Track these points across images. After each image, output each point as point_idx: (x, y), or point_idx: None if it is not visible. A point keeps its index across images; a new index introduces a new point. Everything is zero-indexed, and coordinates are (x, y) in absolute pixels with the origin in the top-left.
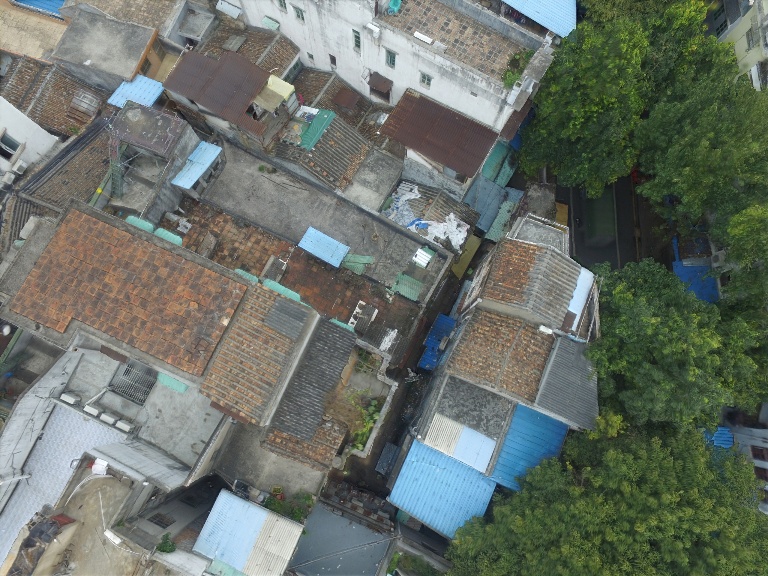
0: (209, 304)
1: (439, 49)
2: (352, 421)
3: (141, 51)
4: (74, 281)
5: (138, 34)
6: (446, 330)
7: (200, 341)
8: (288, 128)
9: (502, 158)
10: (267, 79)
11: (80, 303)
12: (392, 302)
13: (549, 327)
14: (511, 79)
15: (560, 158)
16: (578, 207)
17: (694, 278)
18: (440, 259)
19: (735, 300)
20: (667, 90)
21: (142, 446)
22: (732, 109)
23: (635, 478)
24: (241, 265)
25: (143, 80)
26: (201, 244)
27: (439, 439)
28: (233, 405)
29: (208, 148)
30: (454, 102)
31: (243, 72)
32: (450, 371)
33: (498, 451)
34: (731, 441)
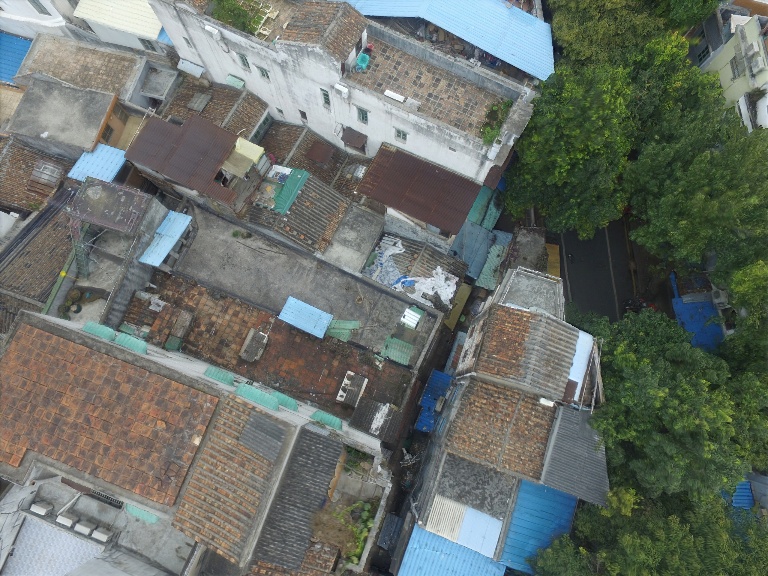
0: (178, 422)
1: (412, 106)
2: (343, 543)
3: (101, 118)
4: (28, 406)
5: (97, 101)
6: (442, 388)
7: (170, 465)
8: (261, 190)
9: (487, 200)
10: (234, 142)
11: (35, 431)
12: (382, 369)
13: (550, 399)
14: (490, 136)
15: (547, 200)
16: (569, 242)
17: (696, 315)
18: (430, 318)
19: (743, 349)
20: (654, 128)
21: (122, 556)
22: (725, 153)
23: (654, 564)
24: (220, 340)
25: (105, 149)
26: (175, 325)
27: (441, 523)
28: (209, 541)
29: (177, 218)
30: (432, 156)
31: (209, 137)
32: (448, 450)
33: (505, 532)
34: (748, 489)
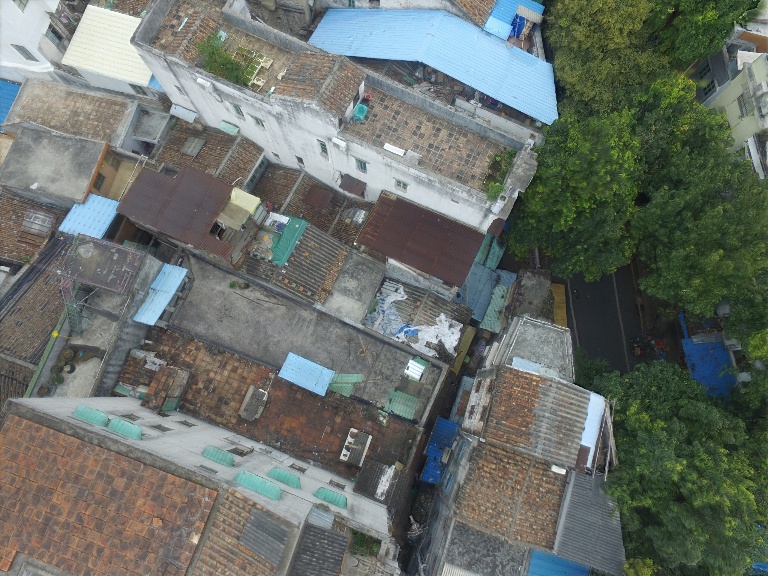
0: (175, 518)
1: (413, 159)
2: None
3: (92, 168)
4: (17, 505)
5: (87, 149)
6: (447, 436)
7: (167, 567)
8: (258, 239)
9: (490, 238)
10: (230, 193)
11: (25, 532)
12: (386, 424)
13: (562, 467)
14: (494, 192)
15: (552, 242)
16: (574, 277)
17: (706, 356)
18: (434, 369)
19: (759, 403)
20: (661, 172)
21: None
22: (737, 205)
23: None
24: (218, 398)
25: (96, 200)
26: (171, 387)
27: None
28: None
29: (172, 272)
30: (434, 205)
31: (203, 188)
32: (457, 519)
33: None
34: None
